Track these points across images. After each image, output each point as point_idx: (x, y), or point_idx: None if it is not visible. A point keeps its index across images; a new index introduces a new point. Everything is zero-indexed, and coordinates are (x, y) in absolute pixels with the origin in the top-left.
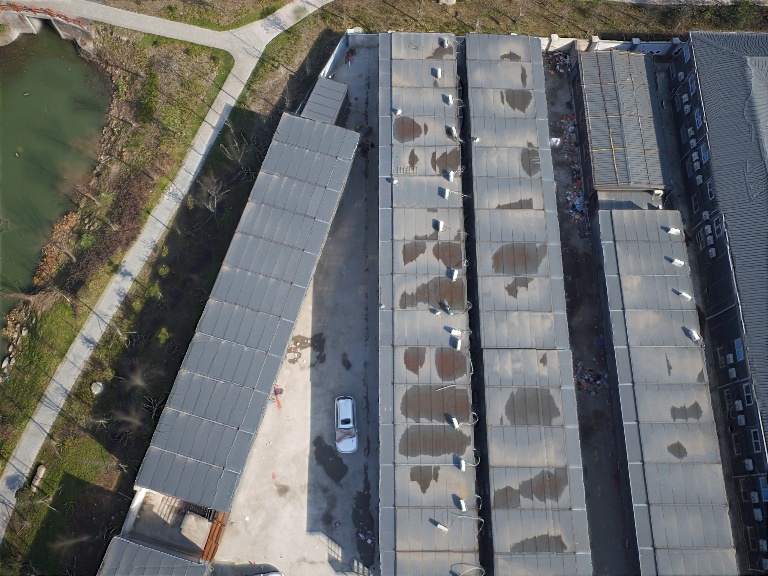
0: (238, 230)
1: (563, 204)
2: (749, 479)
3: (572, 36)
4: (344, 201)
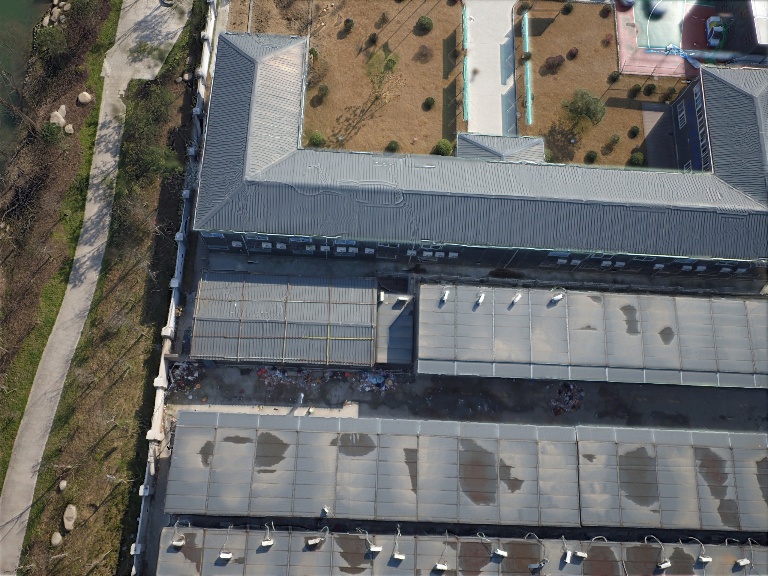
0: None
1: (374, 396)
2: (668, 268)
3: (146, 354)
4: None
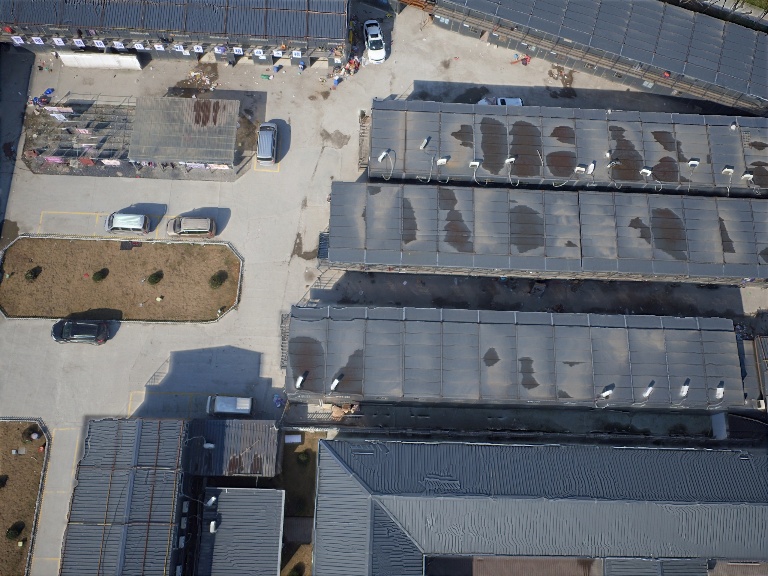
0: (667, 4)
1: None
2: None
3: None
4: None
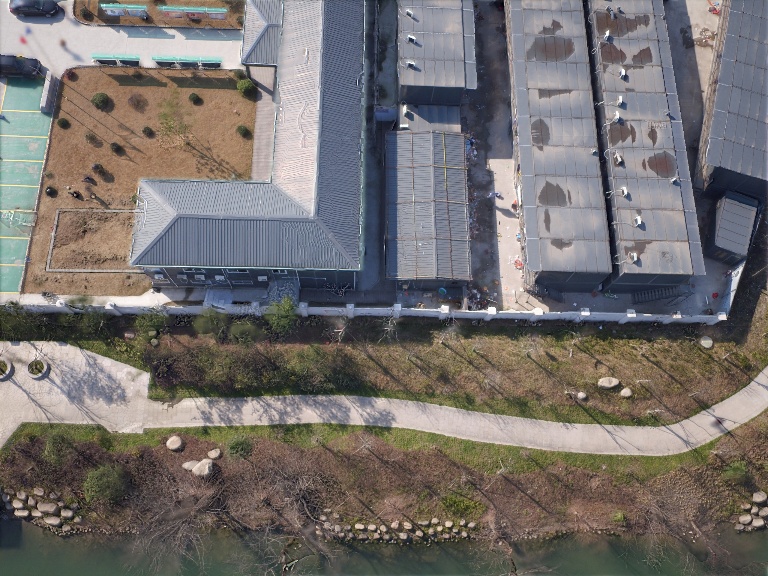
0: None
1: (481, 148)
2: None
3: (459, 338)
4: (688, 152)
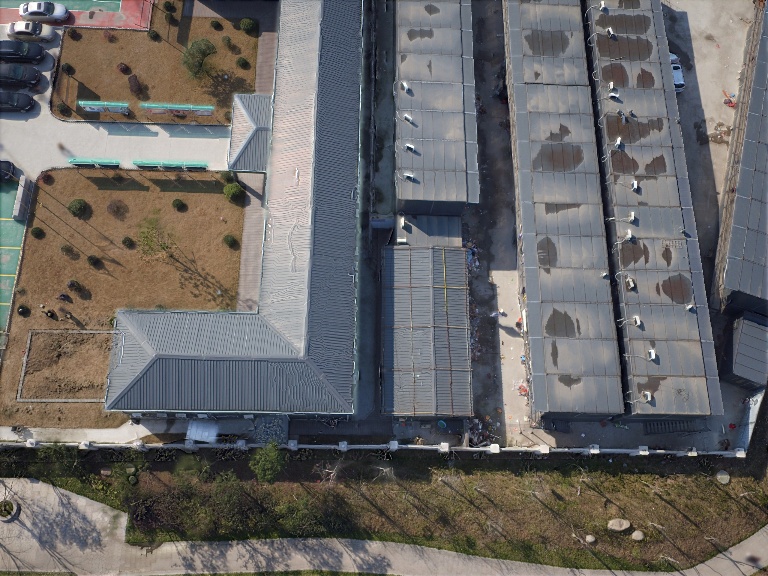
0: None
1: (483, 258)
2: None
3: (460, 474)
4: (703, 262)
